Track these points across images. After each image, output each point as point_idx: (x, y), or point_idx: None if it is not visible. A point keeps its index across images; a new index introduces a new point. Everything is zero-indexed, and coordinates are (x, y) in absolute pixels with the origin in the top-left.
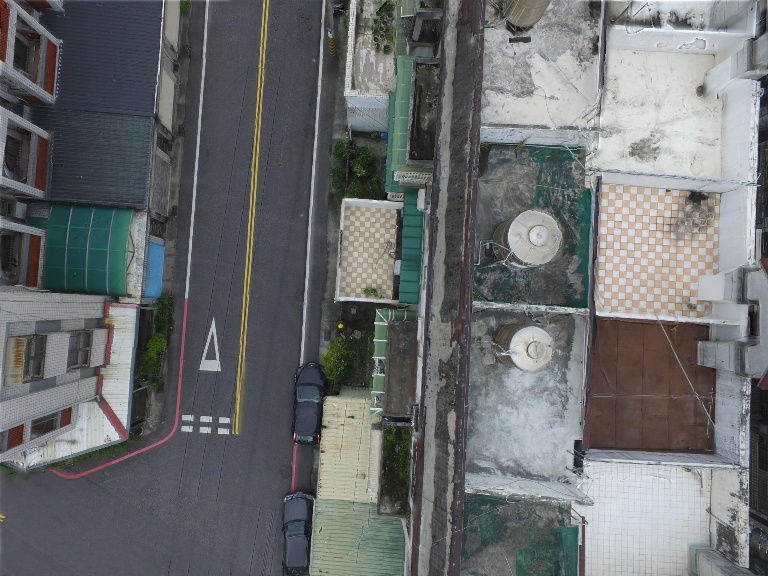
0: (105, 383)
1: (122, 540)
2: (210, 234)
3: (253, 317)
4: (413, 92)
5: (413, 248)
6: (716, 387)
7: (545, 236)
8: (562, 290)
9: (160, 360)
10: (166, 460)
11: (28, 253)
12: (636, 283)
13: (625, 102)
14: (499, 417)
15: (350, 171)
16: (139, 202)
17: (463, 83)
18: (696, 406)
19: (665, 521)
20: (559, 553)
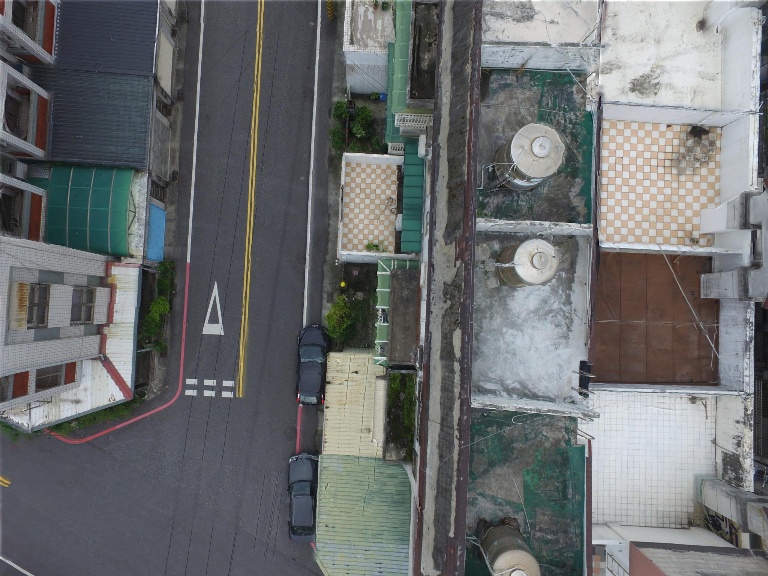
0: (109, 342)
1: (128, 504)
2: (211, 198)
3: (255, 280)
4: (413, 31)
5: (414, 197)
6: (720, 319)
7: (548, 147)
8: (565, 213)
9: (163, 324)
10: (171, 424)
11: (30, 211)
12: (638, 218)
13: (625, 38)
14: (504, 339)
15: (350, 132)
16: (140, 161)
17: (463, 5)
18: (700, 338)
19: (671, 453)
20: (566, 472)
